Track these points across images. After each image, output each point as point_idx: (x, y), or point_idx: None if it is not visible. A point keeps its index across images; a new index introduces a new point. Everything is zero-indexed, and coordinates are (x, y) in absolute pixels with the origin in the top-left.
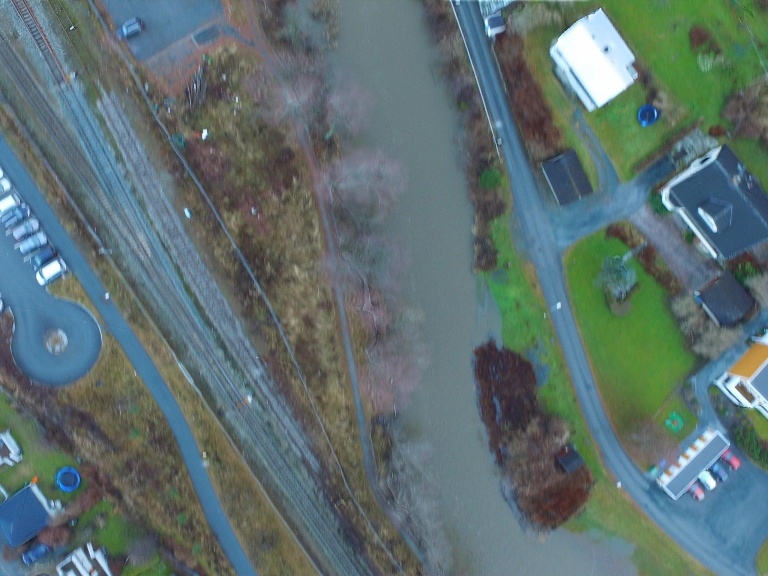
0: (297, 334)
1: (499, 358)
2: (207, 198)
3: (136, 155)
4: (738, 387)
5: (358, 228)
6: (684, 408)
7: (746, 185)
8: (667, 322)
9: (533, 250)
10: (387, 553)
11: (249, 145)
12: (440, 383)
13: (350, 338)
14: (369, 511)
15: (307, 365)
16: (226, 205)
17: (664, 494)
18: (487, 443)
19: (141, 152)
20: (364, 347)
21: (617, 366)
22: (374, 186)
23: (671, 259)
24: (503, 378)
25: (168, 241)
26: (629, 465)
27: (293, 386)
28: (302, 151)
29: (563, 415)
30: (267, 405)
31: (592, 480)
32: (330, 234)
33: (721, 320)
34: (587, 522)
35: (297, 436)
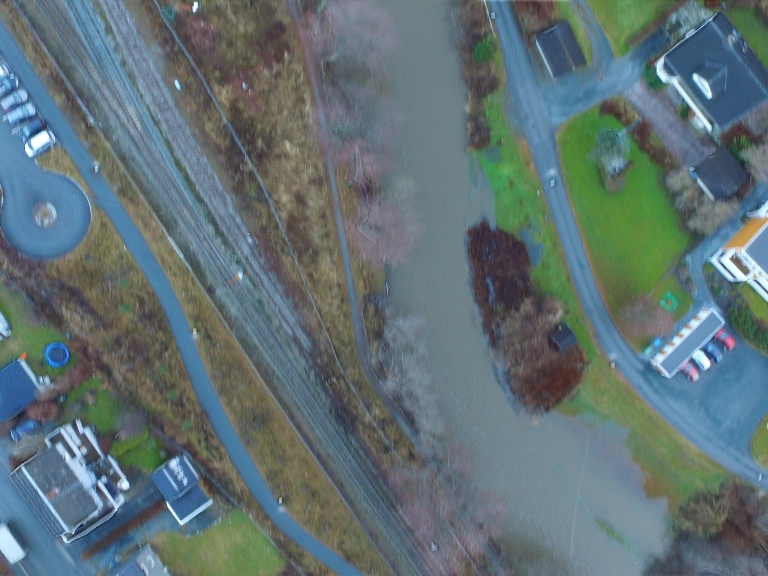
0: (288, 211)
1: (492, 238)
2: (198, 70)
3: (126, 27)
4: (733, 259)
5: (350, 103)
6: (679, 288)
7: (741, 49)
8: (662, 201)
9: (527, 127)
10: (379, 432)
11: (240, 18)
12: (433, 262)
13: (342, 215)
14: (361, 389)
15: (298, 242)
16: (217, 79)
17: (658, 375)
18: (480, 324)
19: (131, 24)
20: (356, 224)
21: (611, 245)
22: (366, 57)
23: (666, 135)
24: (496, 259)
25: (158, 115)
26: (623, 346)
27: (284, 263)
28: (294, 24)
29: (557, 294)
30: (258, 282)
31: (586, 360)
32: (322, 109)
33: (716, 194)
34: (581, 405)
35: (288, 314)
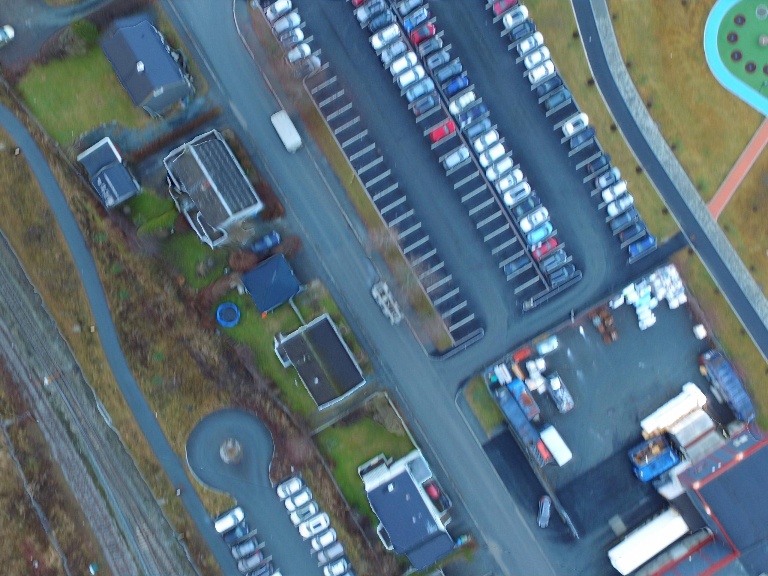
0: None
1: None
2: None
3: None
4: None
5: None
6: None
7: None
8: None
9: None
10: None
11: None
12: None
13: None
14: None
15: None
16: None
17: None
18: None
19: None
20: None
21: None
22: None
23: None
24: None
25: (120, 541)
26: None
27: (4, 390)
28: None
29: None
30: (31, 373)
31: None
32: None
33: None
34: None
35: (2, 340)
